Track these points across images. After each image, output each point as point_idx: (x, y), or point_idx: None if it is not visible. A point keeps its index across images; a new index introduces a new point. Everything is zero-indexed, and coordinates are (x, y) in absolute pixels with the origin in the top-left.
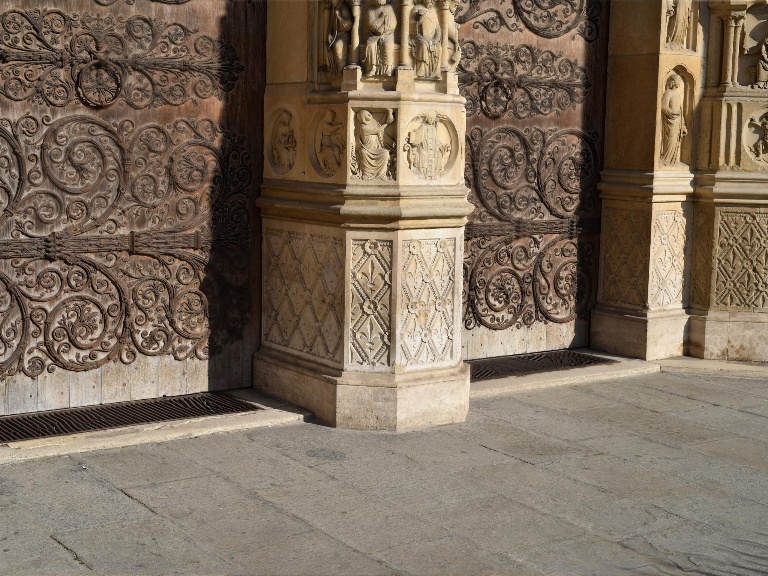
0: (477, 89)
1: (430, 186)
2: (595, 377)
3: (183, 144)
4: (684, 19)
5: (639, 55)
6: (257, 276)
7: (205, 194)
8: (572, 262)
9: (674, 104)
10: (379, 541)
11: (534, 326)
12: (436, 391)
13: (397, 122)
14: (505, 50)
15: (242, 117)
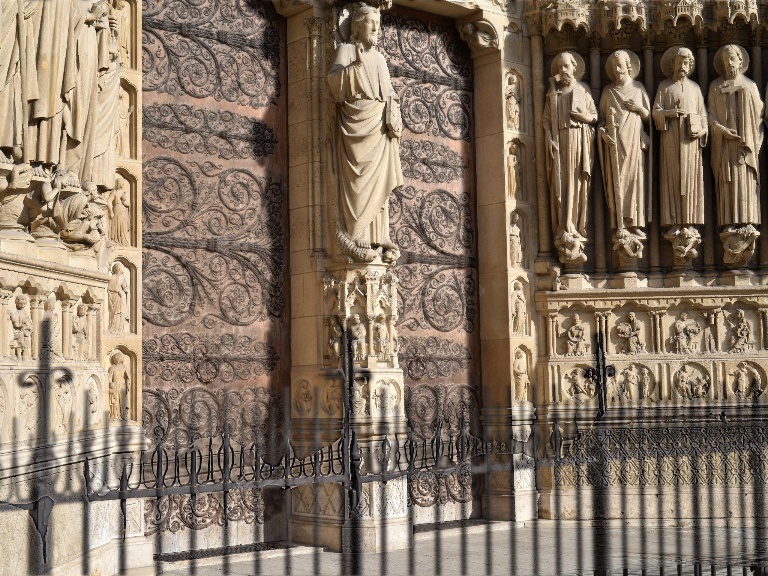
0: (406, 363)
1: (388, 417)
2: (485, 530)
3: (249, 401)
4: (523, 318)
5: (498, 340)
6: None
7: (261, 428)
8: (468, 465)
9: (521, 367)
10: None
11: (447, 505)
12: (396, 530)
13: (369, 384)
14: (421, 340)
15: (279, 385)
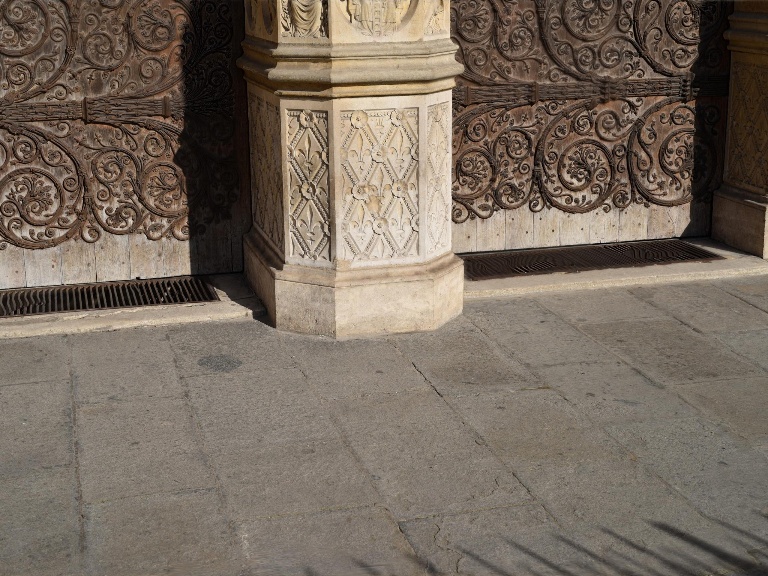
0: None
1: (378, 44)
2: (671, 278)
3: None
4: None
5: None
6: (245, 147)
7: (174, 54)
8: (686, 131)
9: None
10: (121, 487)
11: (629, 209)
12: (391, 293)
13: None
14: None
15: None
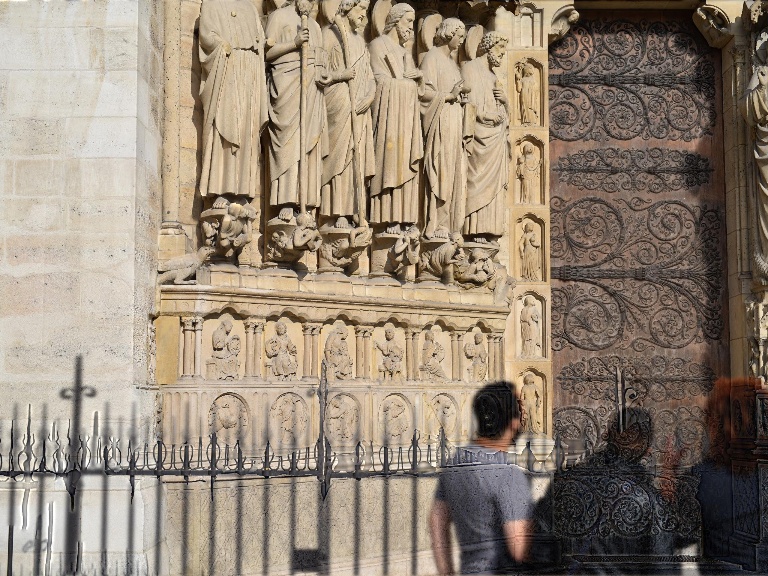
0: None
1: None
2: None
3: (683, 420)
4: None
5: None
6: (730, 493)
7: (697, 446)
8: None
9: None
10: None
11: None
12: None
13: None
14: None
15: (718, 405)
